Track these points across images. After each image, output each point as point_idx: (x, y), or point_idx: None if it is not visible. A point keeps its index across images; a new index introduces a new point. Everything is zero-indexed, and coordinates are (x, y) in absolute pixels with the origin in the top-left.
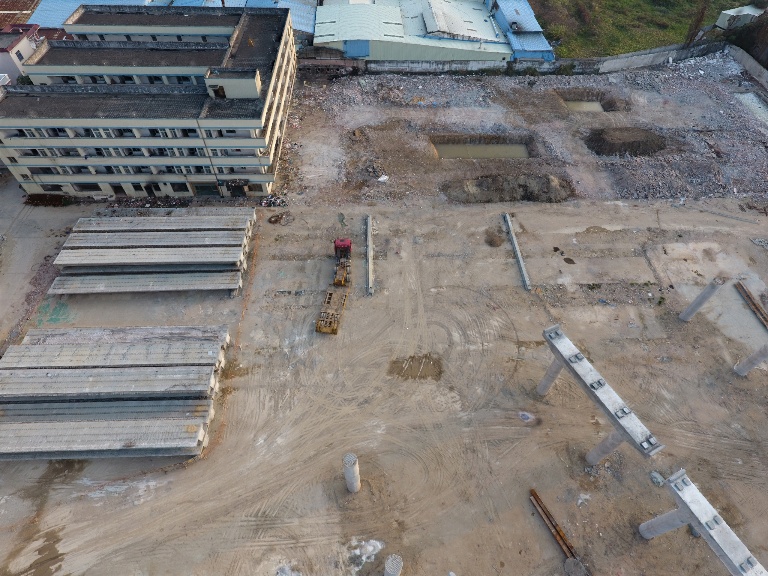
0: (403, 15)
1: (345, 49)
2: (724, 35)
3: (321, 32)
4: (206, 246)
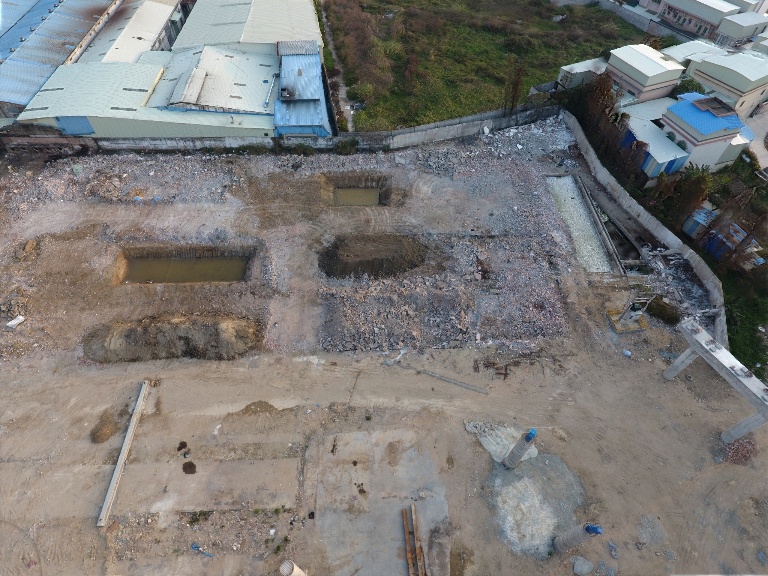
0: (164, 76)
1: (61, 126)
2: (558, 97)
3: (35, 104)
4: None
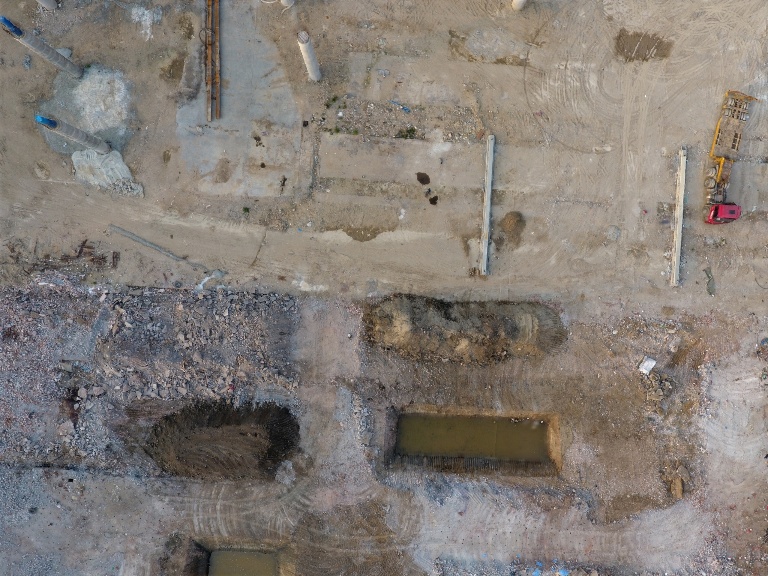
0: None
1: None
2: None
3: None
4: None
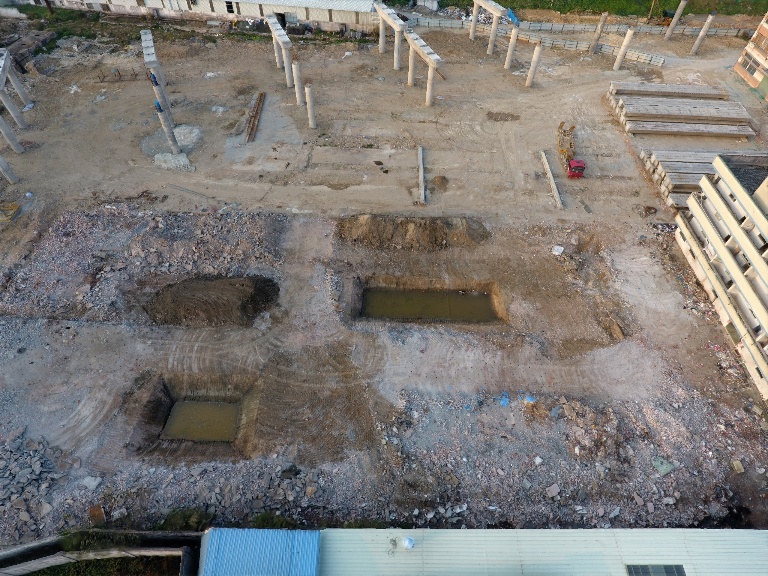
0: None
1: None
2: None
3: None
4: (687, 162)
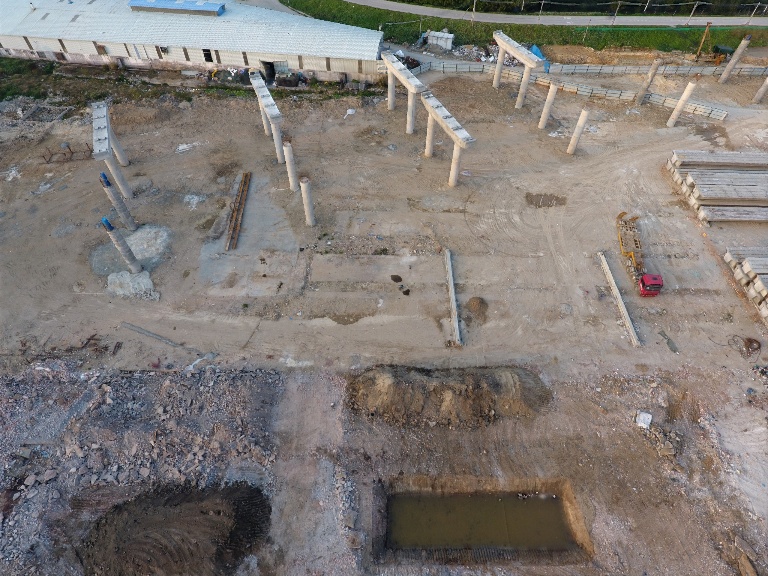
0: None
1: None
2: None
3: None
4: None
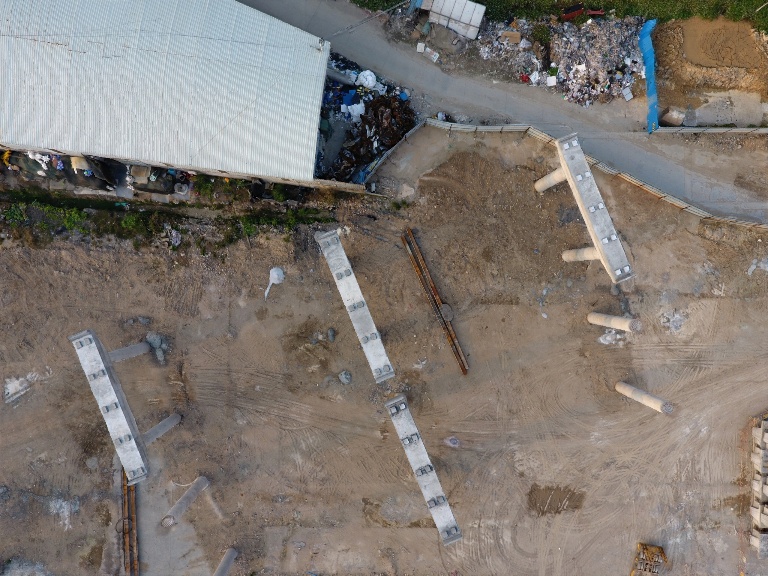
0: None
1: None
2: None
3: None
4: None
